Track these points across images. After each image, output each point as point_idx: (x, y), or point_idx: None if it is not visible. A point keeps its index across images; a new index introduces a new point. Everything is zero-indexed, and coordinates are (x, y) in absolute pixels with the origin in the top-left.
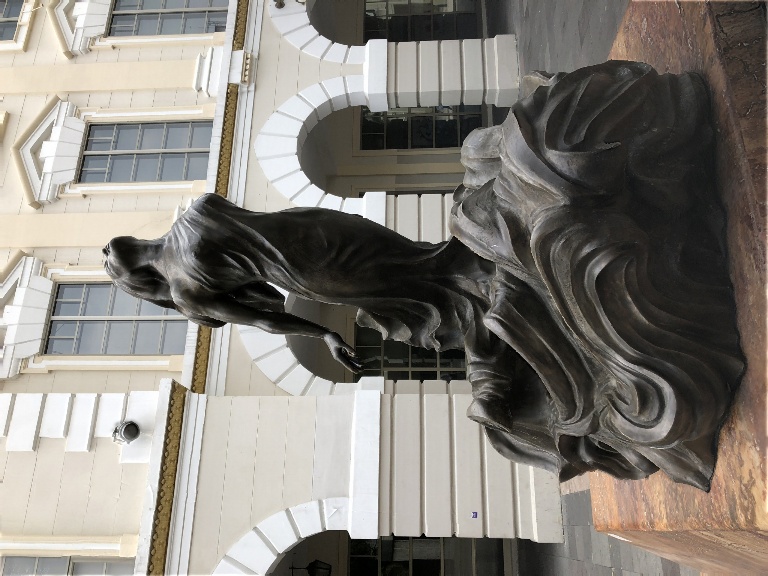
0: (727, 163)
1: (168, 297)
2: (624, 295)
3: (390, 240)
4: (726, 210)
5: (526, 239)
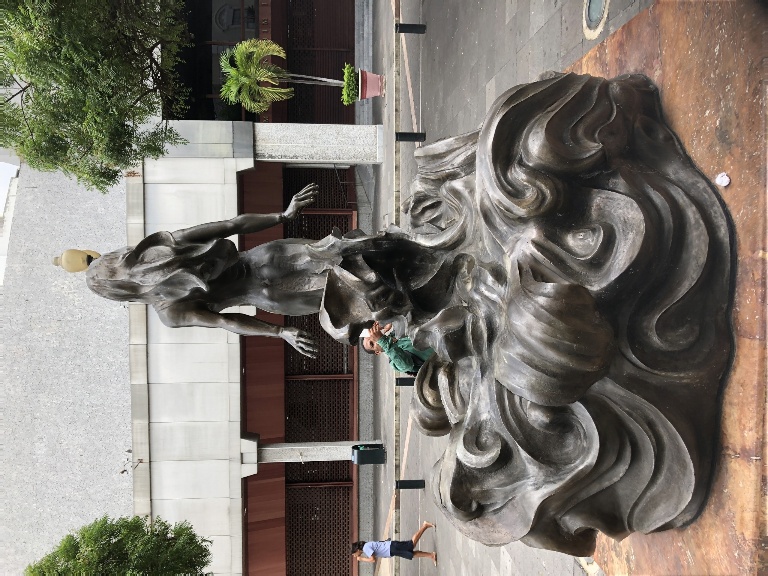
0: None
1: None
2: None
3: None
4: None
5: None
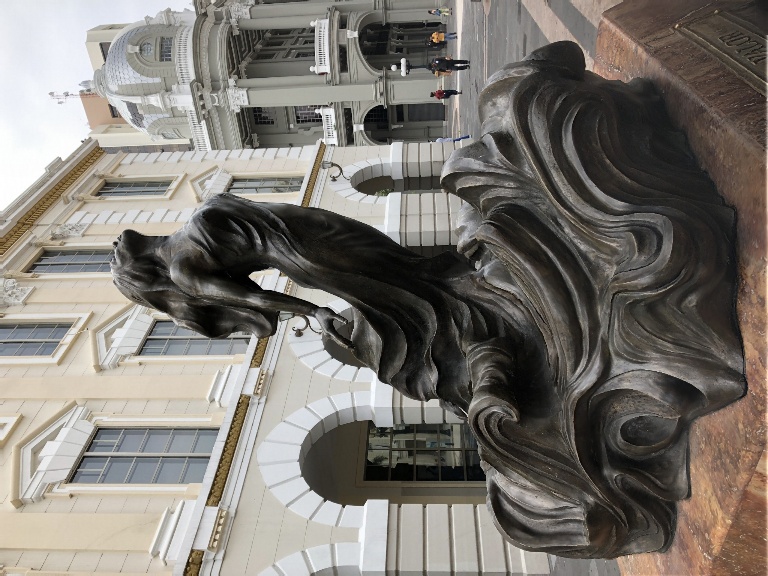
0: (675, 100)
1: (165, 287)
2: (602, 159)
3: (387, 239)
4: (684, 129)
5: (508, 140)
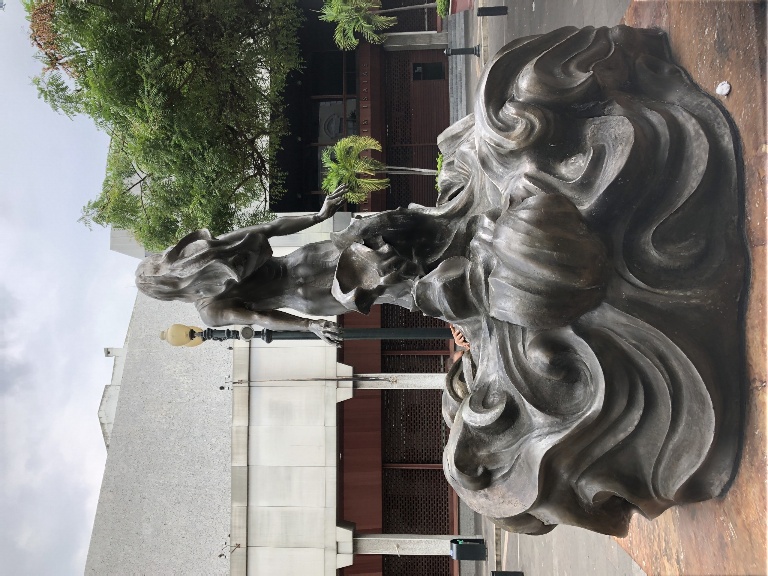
0: None
1: None
2: None
3: None
4: None
5: None
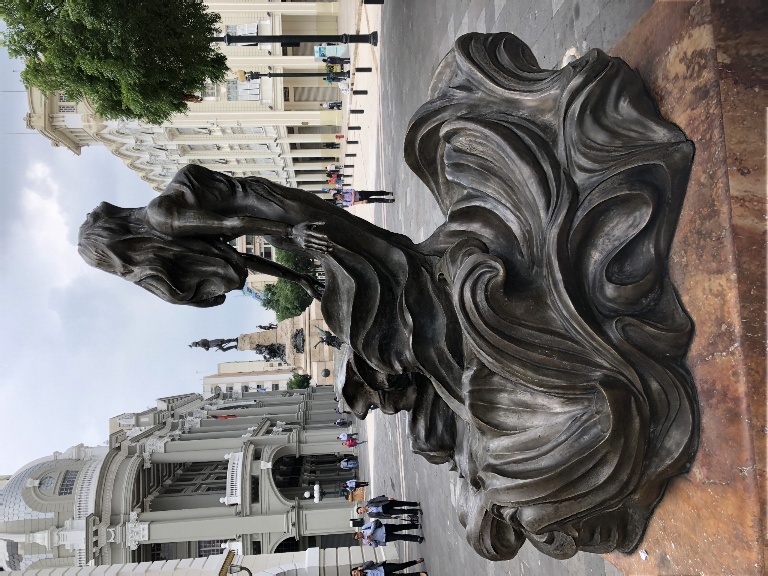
0: None
1: (135, 235)
2: None
3: None
4: None
5: None
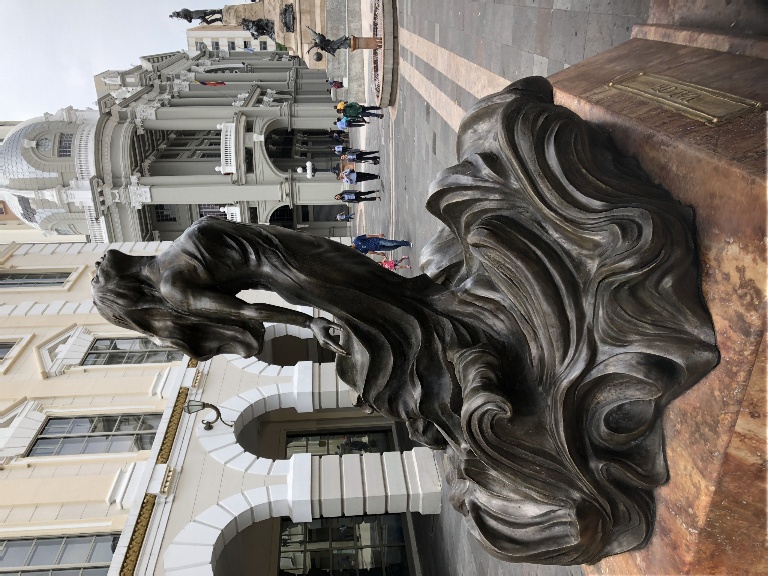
0: (623, 134)
1: (151, 304)
2: (579, 169)
3: (370, 260)
4: (634, 156)
5: (493, 157)
